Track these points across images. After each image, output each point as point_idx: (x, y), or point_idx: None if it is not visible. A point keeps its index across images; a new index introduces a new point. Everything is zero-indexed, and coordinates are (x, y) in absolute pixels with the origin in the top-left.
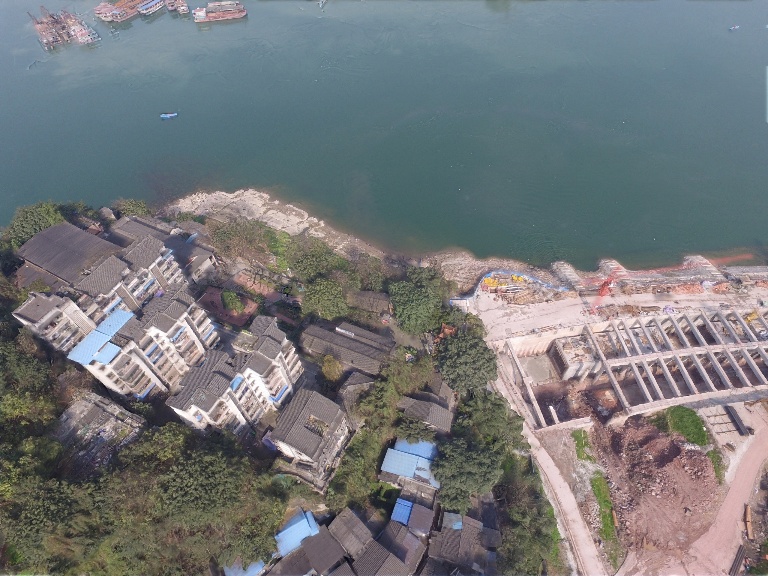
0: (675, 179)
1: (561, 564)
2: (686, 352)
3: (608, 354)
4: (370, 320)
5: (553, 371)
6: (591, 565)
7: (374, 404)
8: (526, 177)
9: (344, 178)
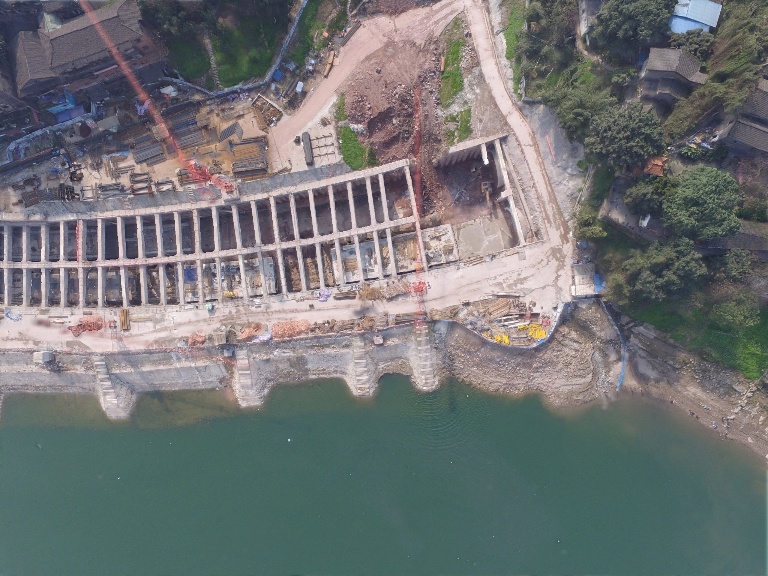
0: (220, 570)
1: (510, 7)
2: (324, 236)
3: (404, 242)
4: (764, 166)
5: (455, 238)
6: (478, 18)
7: (764, 32)
8: (449, 574)
9: (752, 569)
